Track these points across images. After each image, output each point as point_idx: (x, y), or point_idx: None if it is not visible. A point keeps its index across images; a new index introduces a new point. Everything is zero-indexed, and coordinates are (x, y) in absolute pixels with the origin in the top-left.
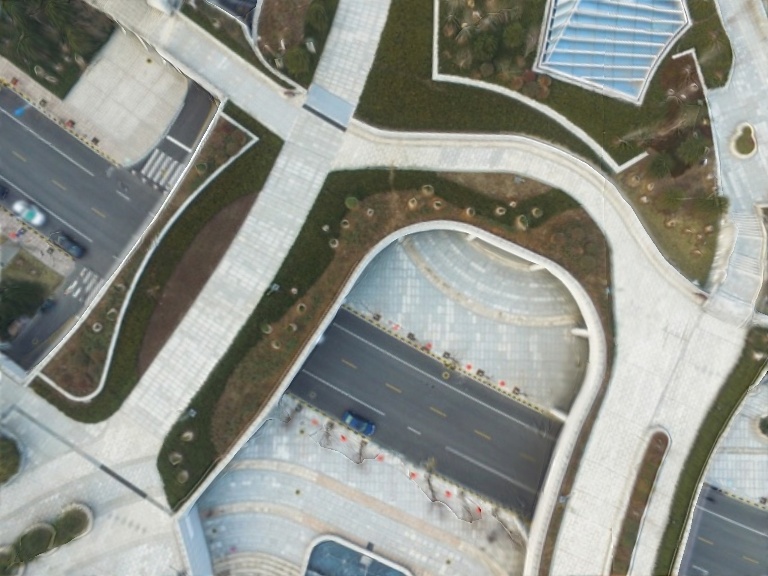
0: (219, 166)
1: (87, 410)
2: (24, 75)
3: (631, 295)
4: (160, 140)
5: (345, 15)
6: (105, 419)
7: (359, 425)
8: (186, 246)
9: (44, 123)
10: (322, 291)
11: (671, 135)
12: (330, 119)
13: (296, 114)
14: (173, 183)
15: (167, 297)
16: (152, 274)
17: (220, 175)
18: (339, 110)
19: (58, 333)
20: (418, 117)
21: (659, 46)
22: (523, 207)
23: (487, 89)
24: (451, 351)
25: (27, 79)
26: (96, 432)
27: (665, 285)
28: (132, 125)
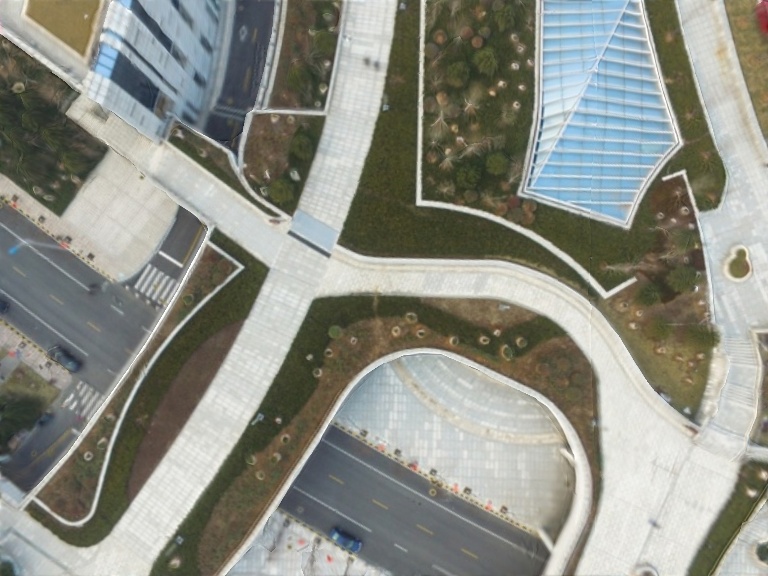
0: (205, 295)
1: (79, 534)
2: (24, 193)
3: (618, 427)
4: (153, 255)
5: (330, 141)
6: (97, 543)
7: (346, 542)
8: (173, 375)
9: (43, 239)
10: (306, 420)
11: (660, 263)
12: (315, 245)
13: (281, 241)
14: (165, 298)
15: (155, 426)
16: (141, 403)
17: (206, 304)
18: (324, 236)
19: (55, 445)
20: (402, 243)
21: (648, 168)
22: (507, 336)
23: (471, 214)
24: (438, 468)
25: (27, 196)
26: (88, 555)
27: (654, 416)
28: (126, 241)
